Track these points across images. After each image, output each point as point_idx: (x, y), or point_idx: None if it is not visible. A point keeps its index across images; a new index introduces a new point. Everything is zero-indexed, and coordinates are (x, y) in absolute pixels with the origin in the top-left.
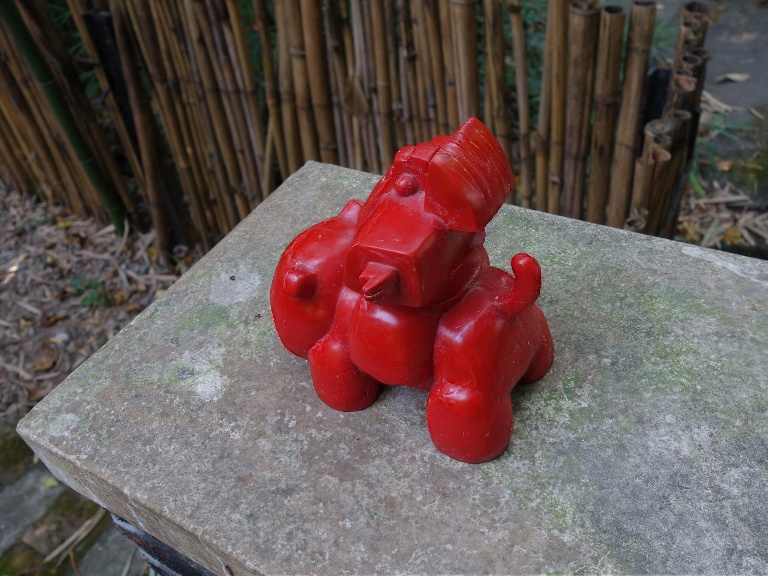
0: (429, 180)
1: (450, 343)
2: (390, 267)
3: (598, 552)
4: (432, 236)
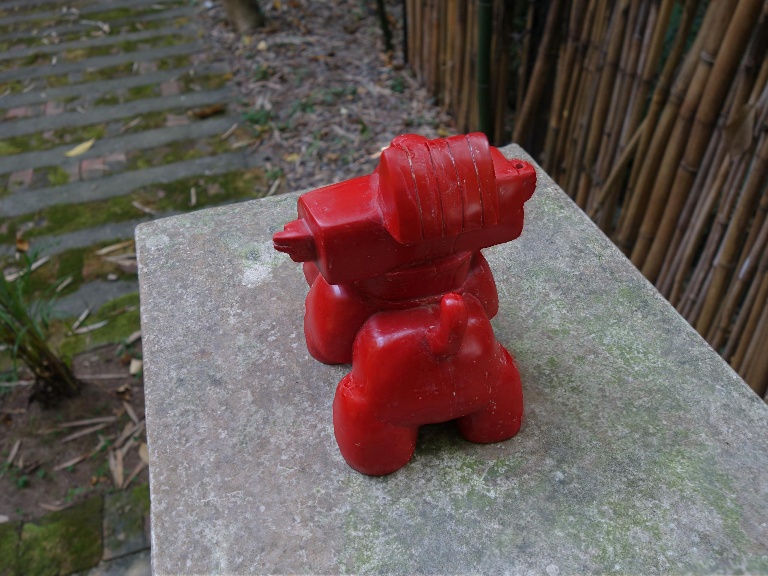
0: (380, 169)
1: (365, 340)
2: (310, 230)
3: None
4: (359, 223)
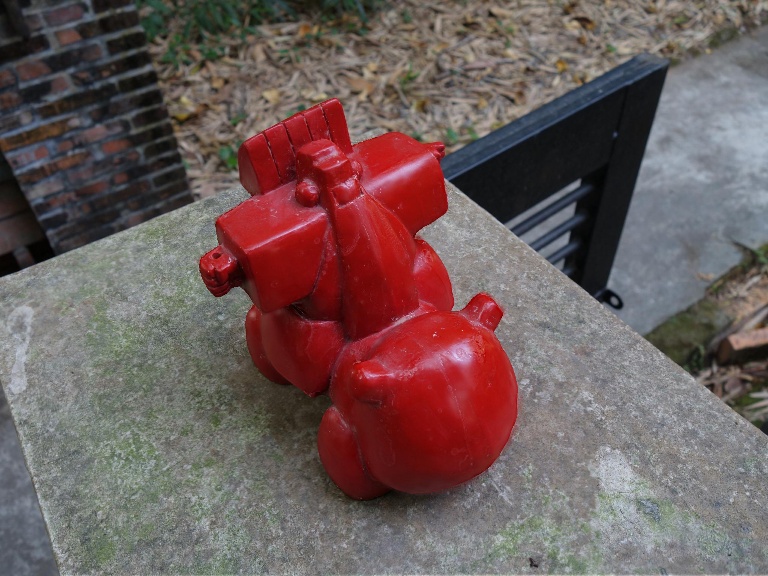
0: None
1: None
2: None
3: None
4: None
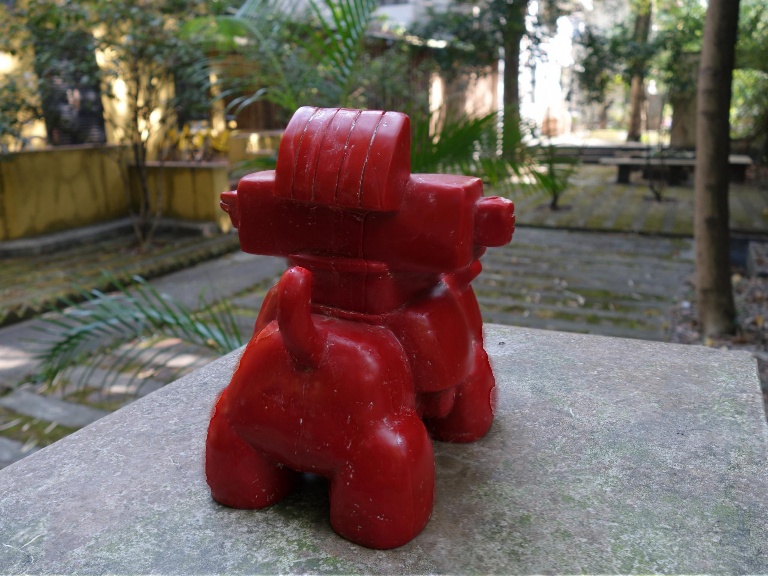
0: None
1: (262, 331)
2: None
3: (43, 575)
4: (268, 183)
